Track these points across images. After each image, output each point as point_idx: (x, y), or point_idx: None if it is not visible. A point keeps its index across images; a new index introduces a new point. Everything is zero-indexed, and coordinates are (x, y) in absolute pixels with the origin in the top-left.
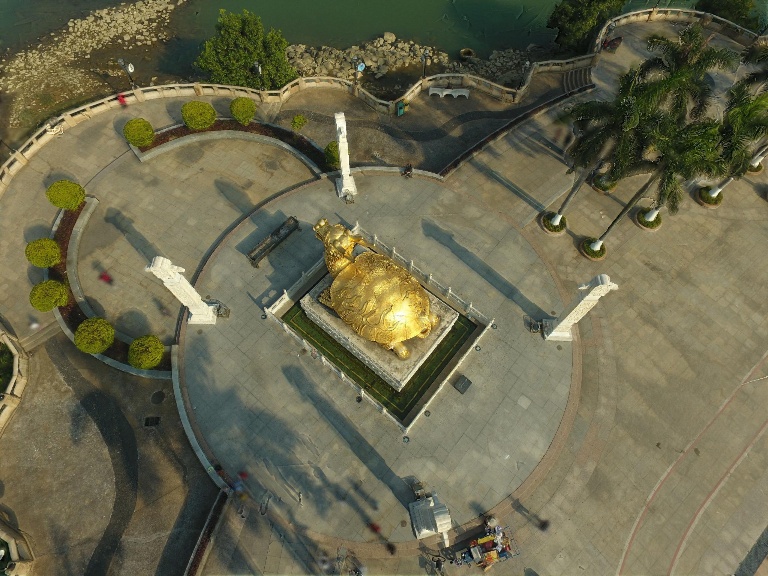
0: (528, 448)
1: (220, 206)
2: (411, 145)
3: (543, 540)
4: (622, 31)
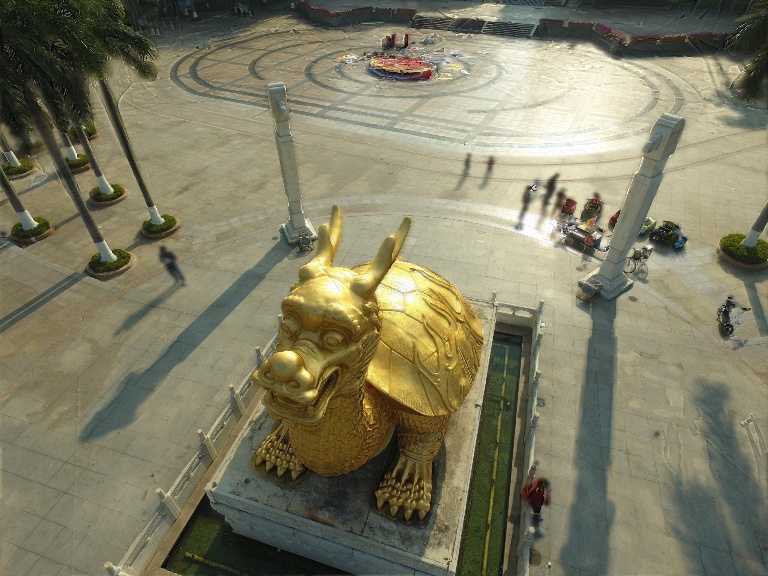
0: (458, 230)
1: None
2: None
3: (531, 215)
4: None
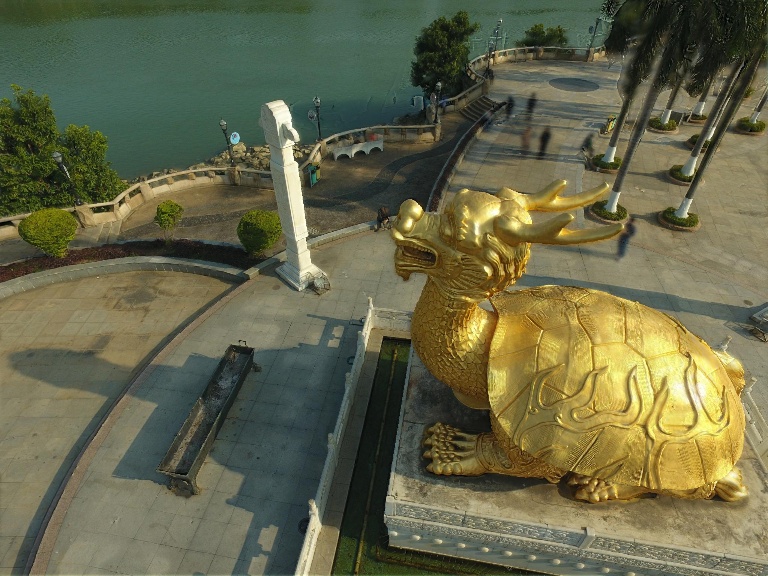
0: None
1: (42, 407)
2: (353, 207)
3: None
4: (480, 73)
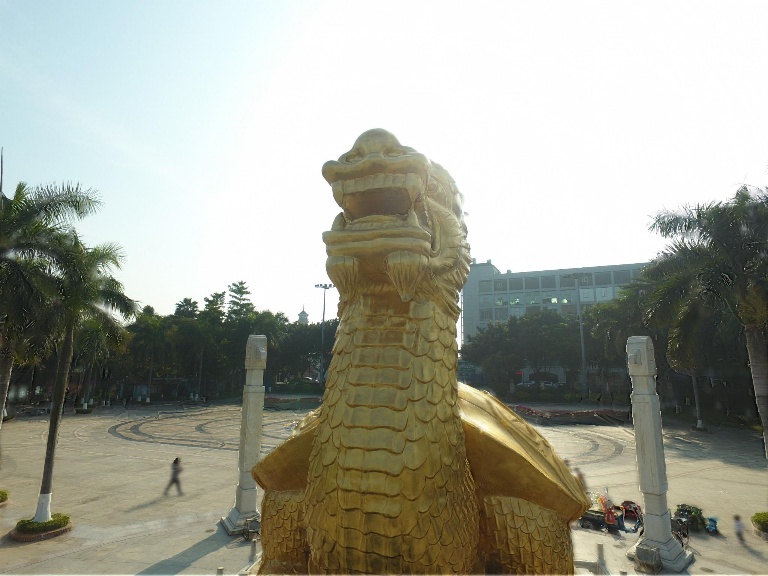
0: None
1: None
2: None
3: None
4: None
